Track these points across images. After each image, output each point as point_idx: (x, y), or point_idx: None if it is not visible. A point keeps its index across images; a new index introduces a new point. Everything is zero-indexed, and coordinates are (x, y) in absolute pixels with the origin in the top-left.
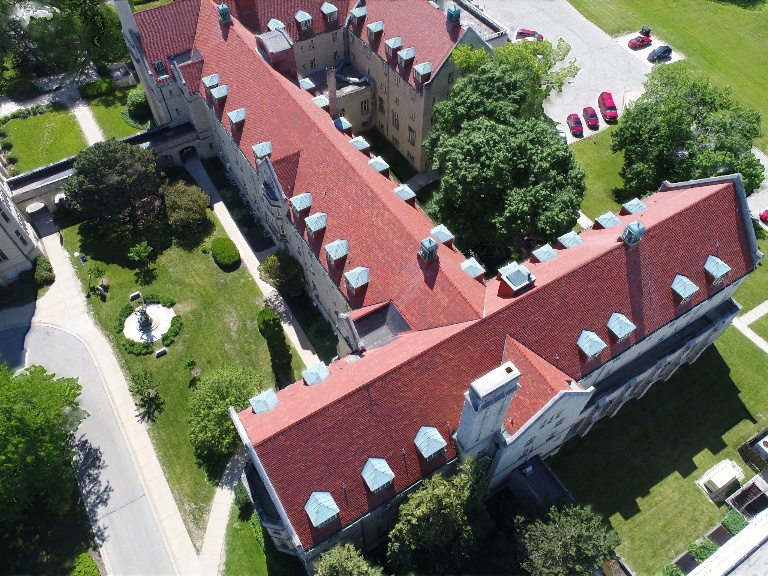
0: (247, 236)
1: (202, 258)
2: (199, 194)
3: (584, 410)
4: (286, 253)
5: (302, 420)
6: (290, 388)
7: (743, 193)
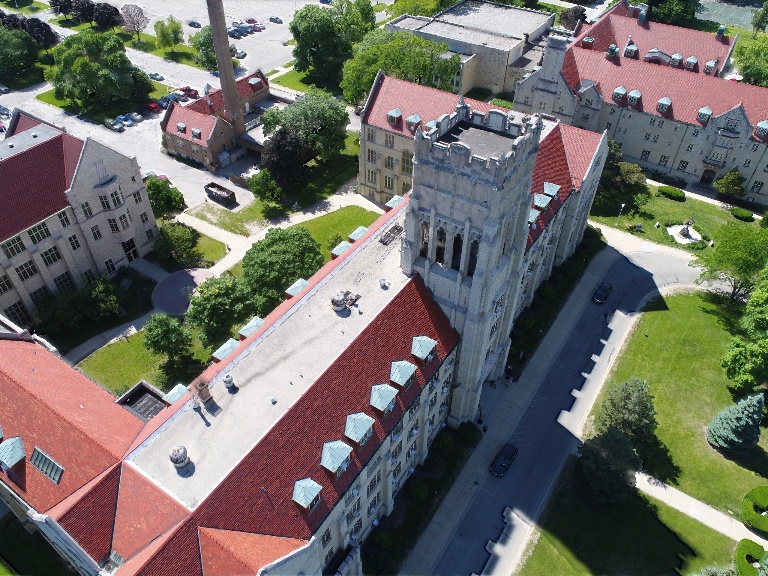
0: (666, 184)
1: (661, 199)
2: (633, 164)
3: None
4: (737, 169)
5: None
6: None
7: None
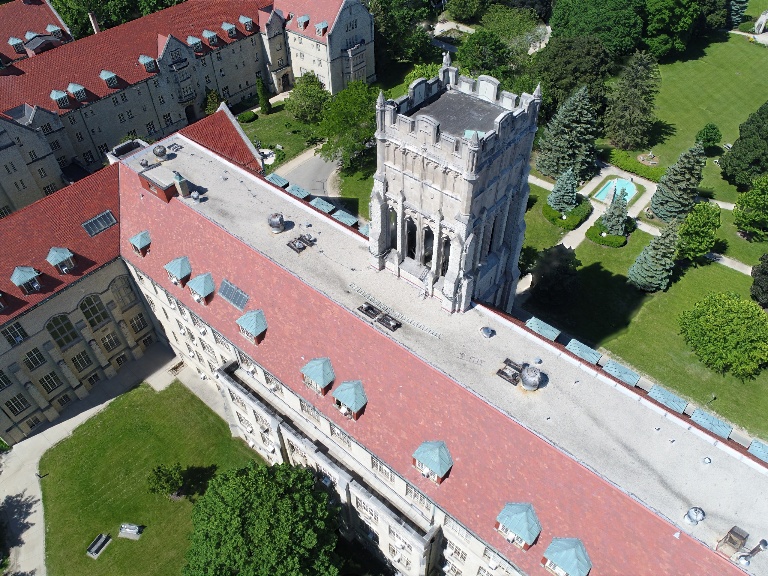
0: None
1: None
2: None
3: None
4: (208, 89)
5: None
6: (310, 32)
7: None
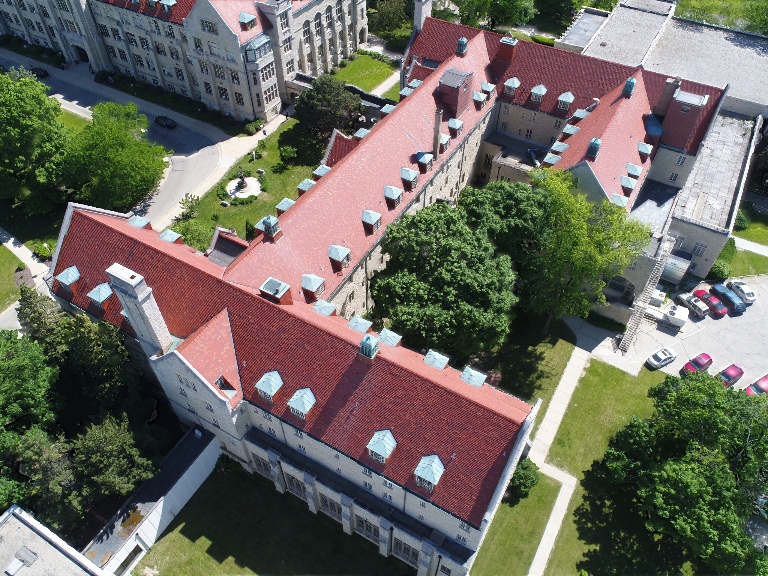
0: None
1: None
2: None
3: (256, 444)
4: None
5: (99, 222)
6: None
7: (517, 442)
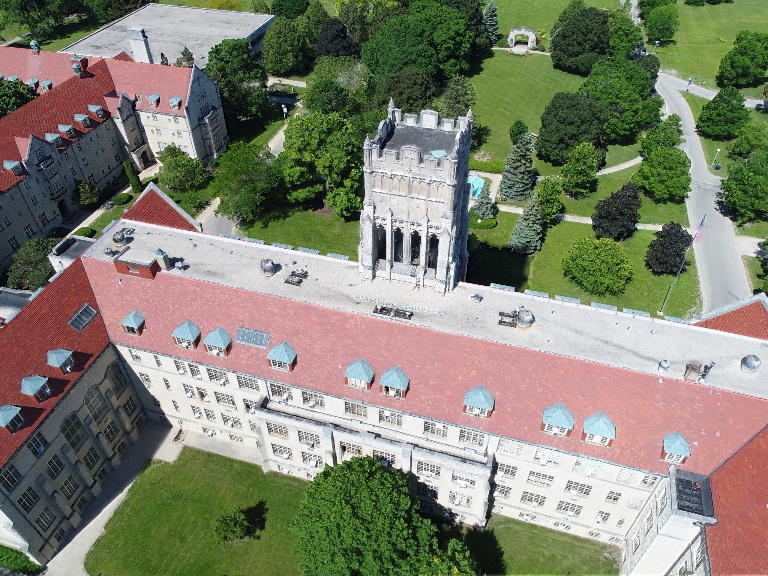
0: None
1: None
2: None
3: None
4: (77, 180)
5: None
6: (163, 108)
7: None
